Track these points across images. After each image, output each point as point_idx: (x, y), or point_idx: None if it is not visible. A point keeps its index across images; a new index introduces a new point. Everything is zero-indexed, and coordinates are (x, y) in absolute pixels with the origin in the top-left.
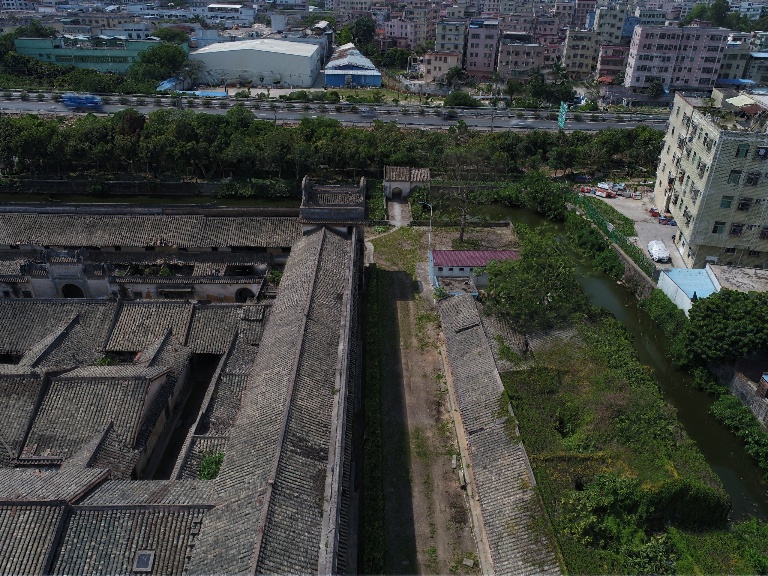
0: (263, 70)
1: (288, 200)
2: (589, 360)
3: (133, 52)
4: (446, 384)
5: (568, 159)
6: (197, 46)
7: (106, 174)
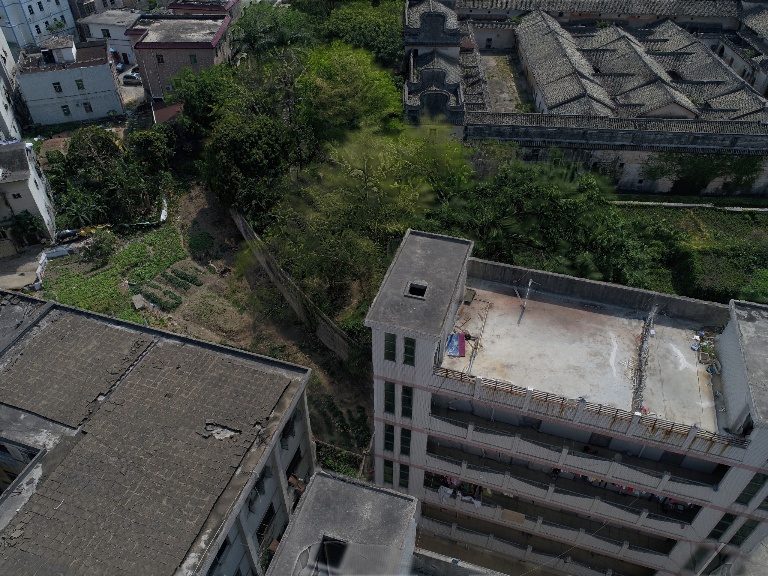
0: None
1: None
2: None
3: None
4: None
5: None
6: None
7: None
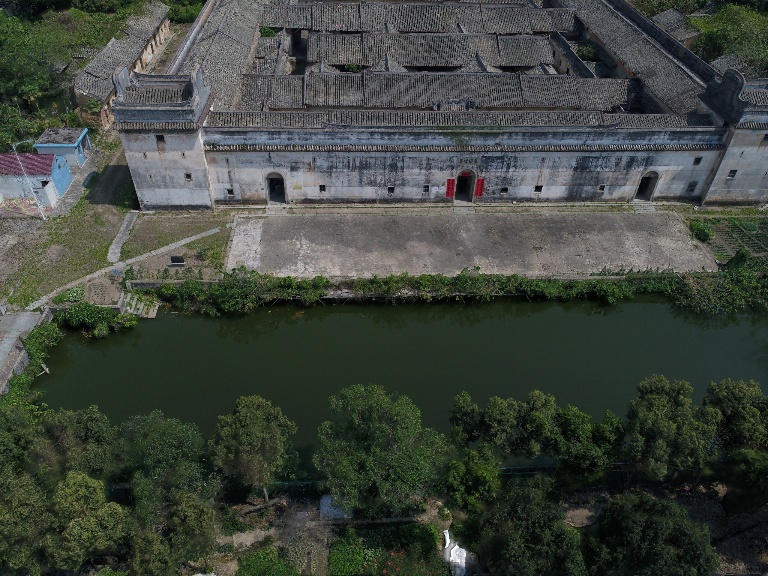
0: None
1: None
2: None
3: None
4: None
5: None
6: None
7: None
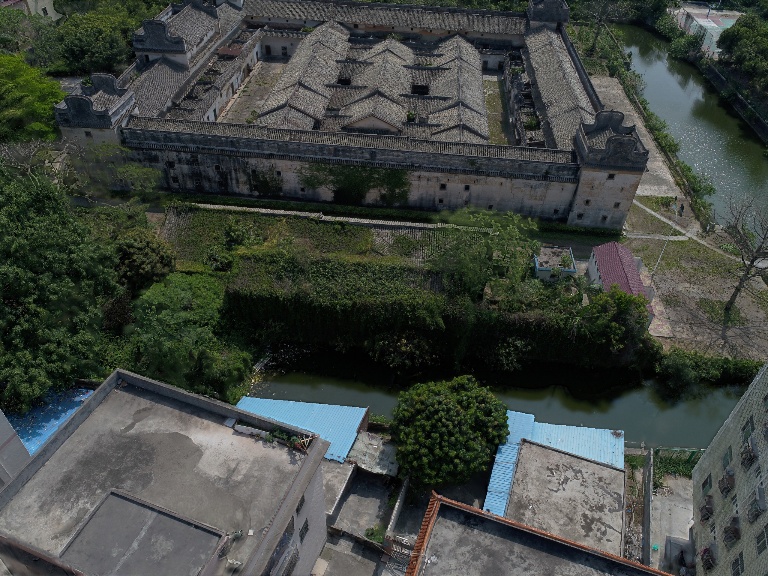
0: None
1: None
2: None
3: None
4: None
5: None
6: None
7: (767, 94)
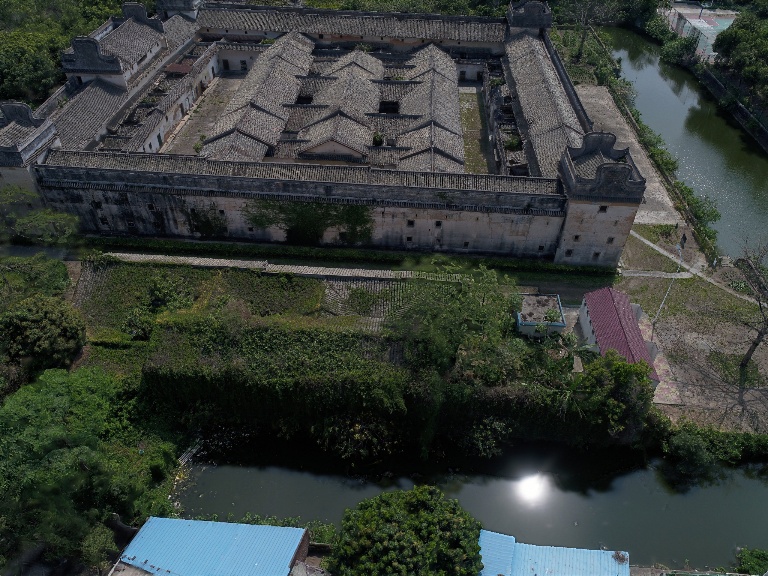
0: None
1: None
2: None
3: None
4: None
5: None
6: None
7: None
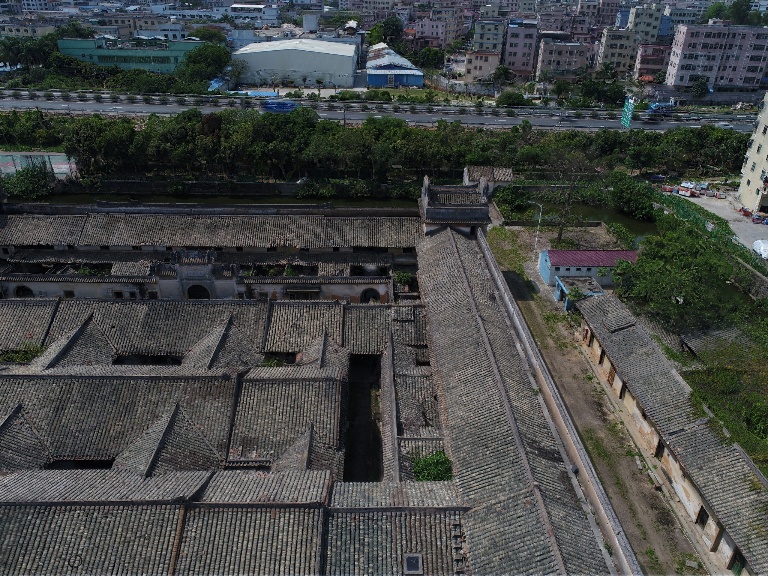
0: (305, 70)
1: (368, 200)
2: (765, 360)
3: (175, 52)
4: (600, 384)
5: (647, 158)
6: (233, 46)
7: (181, 174)
